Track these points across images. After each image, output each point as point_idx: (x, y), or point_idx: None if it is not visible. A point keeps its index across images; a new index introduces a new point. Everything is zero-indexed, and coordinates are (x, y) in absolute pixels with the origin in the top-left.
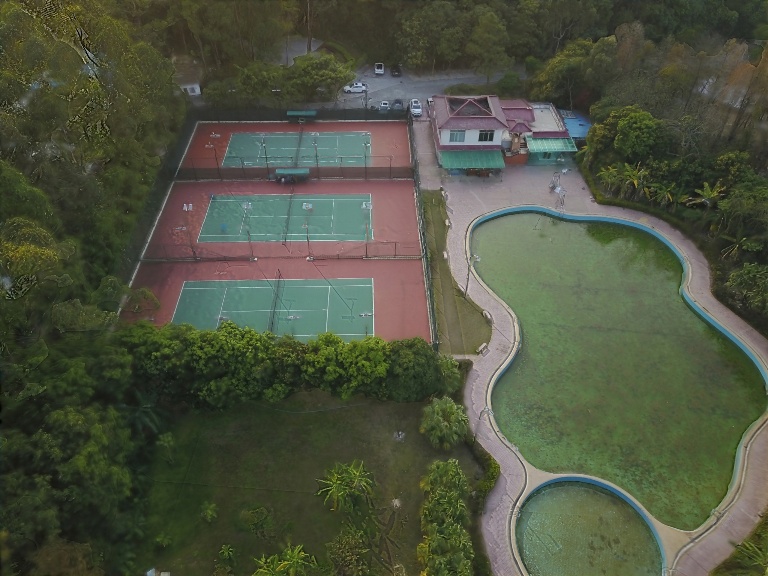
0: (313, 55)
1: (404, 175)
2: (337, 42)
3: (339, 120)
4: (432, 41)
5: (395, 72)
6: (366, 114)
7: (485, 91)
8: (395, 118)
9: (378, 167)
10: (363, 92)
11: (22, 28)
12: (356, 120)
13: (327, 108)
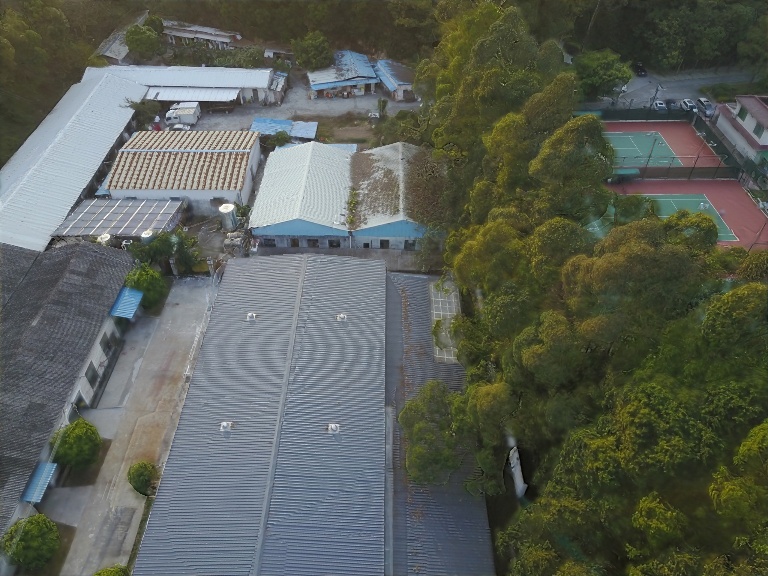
0: (600, 55)
1: (728, 175)
2: (574, 42)
3: (620, 120)
4: (689, 41)
5: (642, 72)
6: (648, 114)
7: (750, 91)
8: (676, 118)
9: (707, 167)
10: (622, 92)
11: (516, 28)
12: (637, 120)
13: (609, 108)
